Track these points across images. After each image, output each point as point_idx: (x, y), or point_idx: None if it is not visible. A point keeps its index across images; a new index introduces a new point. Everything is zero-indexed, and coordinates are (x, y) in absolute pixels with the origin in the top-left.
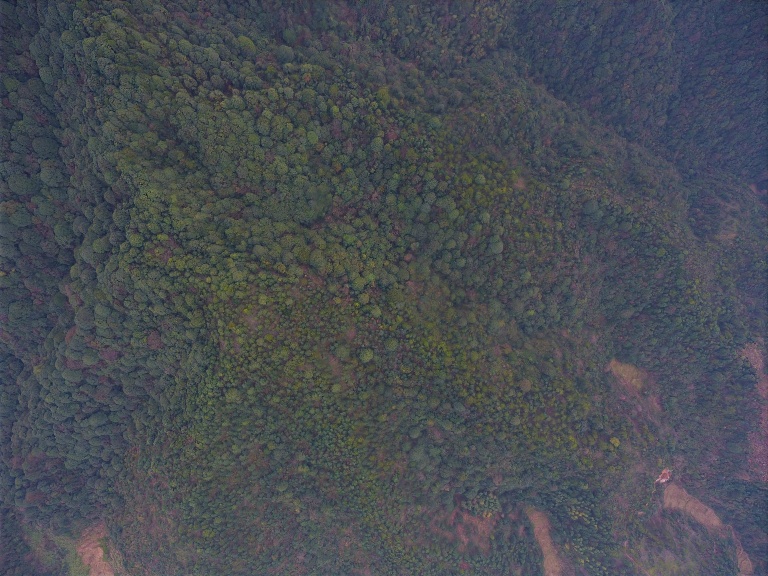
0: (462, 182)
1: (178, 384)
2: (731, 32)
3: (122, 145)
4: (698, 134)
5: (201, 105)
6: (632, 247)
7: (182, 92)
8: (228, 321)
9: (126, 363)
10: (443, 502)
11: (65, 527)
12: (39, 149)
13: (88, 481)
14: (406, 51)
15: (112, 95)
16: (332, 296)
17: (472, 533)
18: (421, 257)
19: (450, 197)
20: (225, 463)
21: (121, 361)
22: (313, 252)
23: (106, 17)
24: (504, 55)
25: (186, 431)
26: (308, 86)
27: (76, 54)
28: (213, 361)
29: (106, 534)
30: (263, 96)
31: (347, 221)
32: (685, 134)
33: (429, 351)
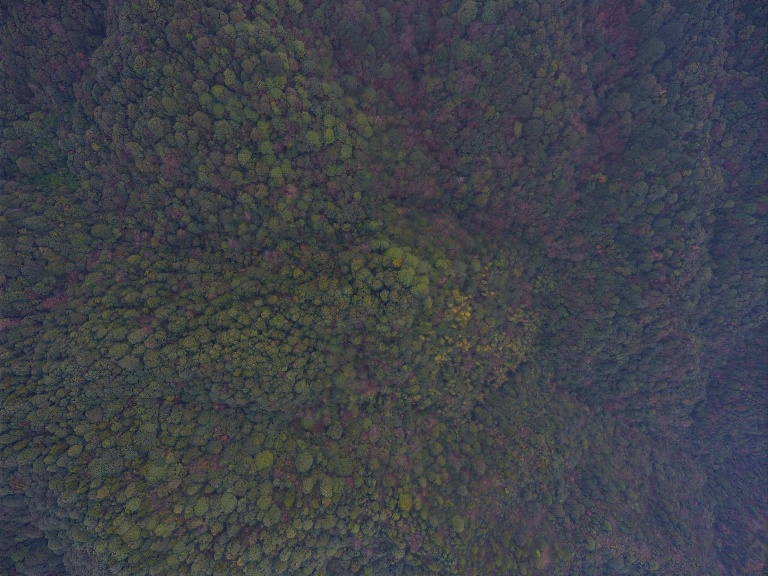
0: None
1: None
2: (762, 353)
3: None
4: (724, 438)
5: (217, 575)
6: None
7: (197, 563)
8: None
9: None
10: None
11: None
12: None
13: None
14: (427, 406)
15: None
16: None
17: None
18: None
19: None
20: None
21: None
22: None
23: (119, 520)
24: (527, 376)
25: None
26: (328, 512)
27: (87, 548)
28: None
29: None
30: (281, 538)
31: None
32: (711, 436)
33: None
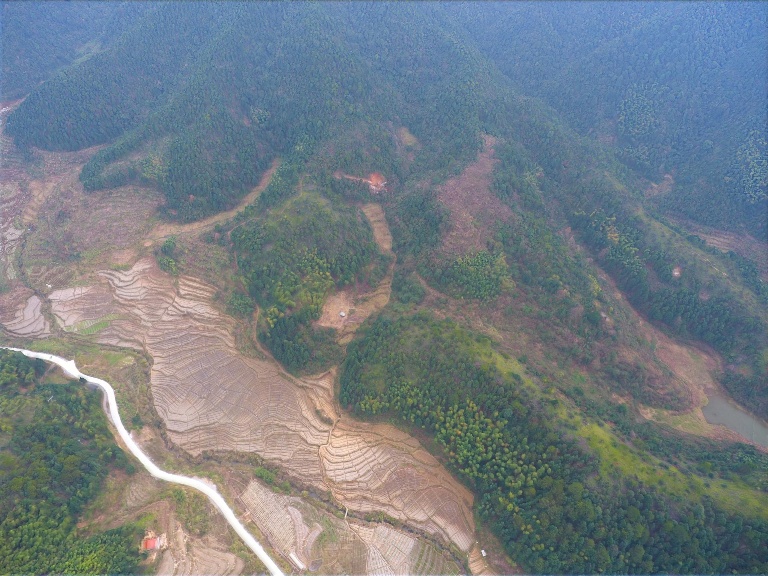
0: None
1: None
2: None
3: None
4: None
5: None
6: None
7: None
8: None
9: None
10: None
11: (108, 37)
12: None
13: None
14: None
15: None
16: None
17: None
18: None
19: None
20: None
21: None
22: None
23: None
24: None
25: None
26: None
27: None
28: None
29: None
30: None
31: None
32: None
33: None
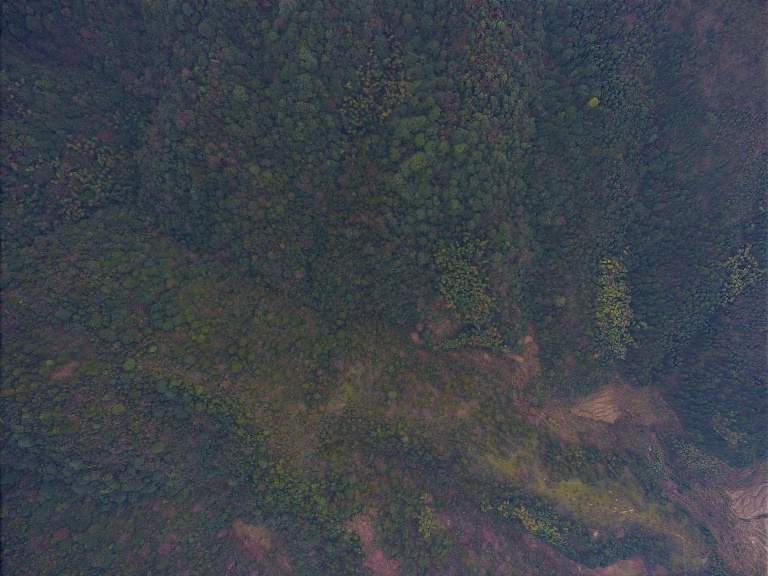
0: None
1: None
2: None
3: None
4: (336, 289)
5: None
6: (217, 423)
7: None
8: None
9: None
10: None
11: None
12: None
13: None
14: None
15: None
16: None
17: None
18: None
19: None
20: None
21: None
22: None
23: None
24: (111, 213)
25: None
26: None
27: None
28: None
29: None
30: None
31: None
32: (325, 288)
33: None
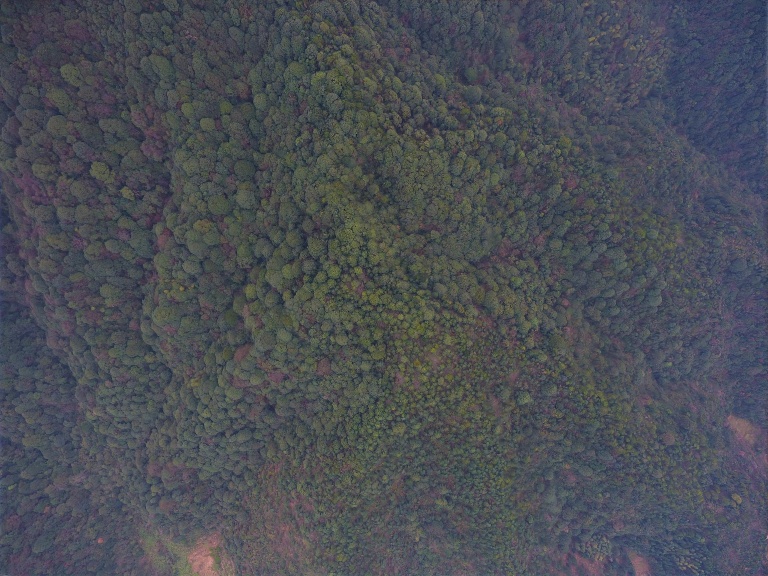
0: (635, 235)
1: (336, 410)
2: None
3: (334, 178)
4: None
5: (410, 144)
6: None
7: (393, 130)
8: (413, 358)
9: (290, 386)
10: (560, 543)
11: (184, 535)
12: (241, 172)
13: (217, 493)
14: (572, 96)
15: (333, 129)
16: (502, 338)
17: (584, 575)
18: (575, 303)
19: (622, 249)
20: (374, 492)
21: (286, 384)
22: (489, 294)
23: (338, 53)
24: (655, 104)
25: (343, 458)
26: (500, 130)
27: (301, 86)
28: (388, 395)
29: (220, 544)
30: (461, 137)
31: (511, 262)
32: None
33: (586, 399)
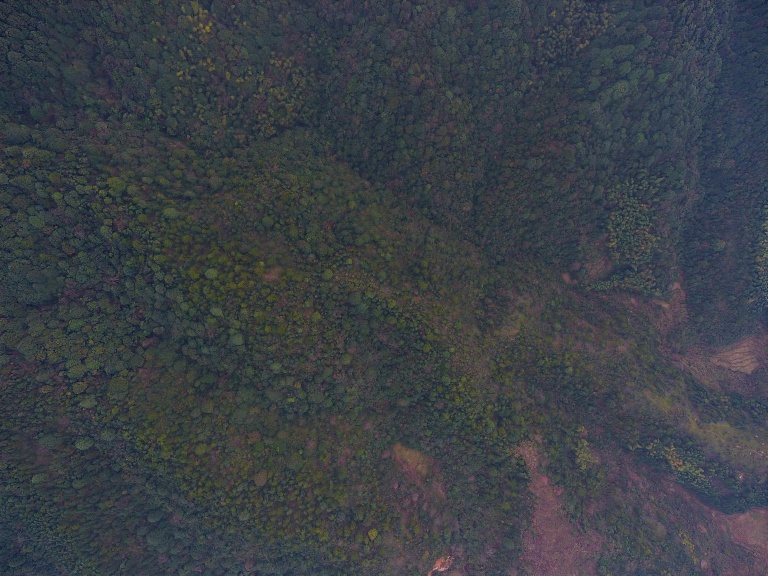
0: (190, 276)
1: None
2: (529, 127)
3: None
4: (502, 222)
5: None
6: (401, 340)
7: None
8: None
9: None
10: None
11: None
12: None
13: None
14: (176, 130)
15: None
16: (42, 384)
17: None
18: (165, 342)
19: (177, 290)
20: None
21: None
22: (22, 339)
23: None
24: (298, 134)
25: None
26: (27, 172)
27: None
28: None
29: None
30: None
31: (83, 303)
32: (490, 221)
33: (147, 443)
